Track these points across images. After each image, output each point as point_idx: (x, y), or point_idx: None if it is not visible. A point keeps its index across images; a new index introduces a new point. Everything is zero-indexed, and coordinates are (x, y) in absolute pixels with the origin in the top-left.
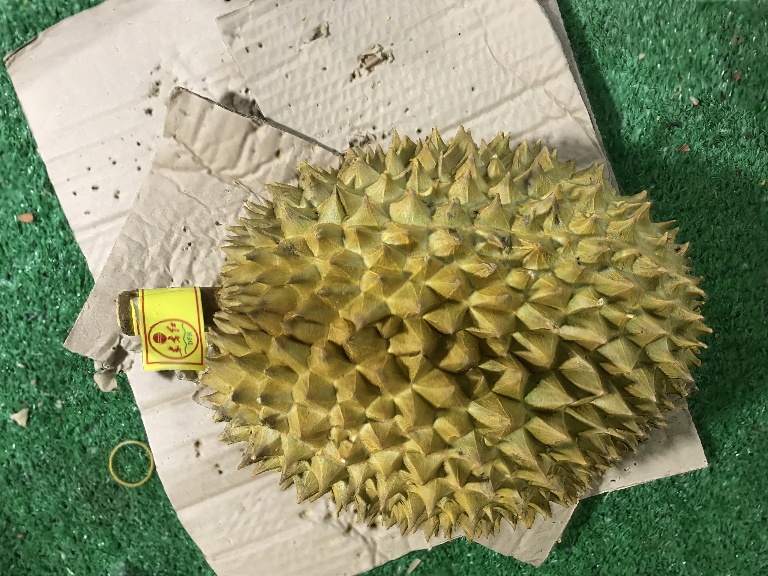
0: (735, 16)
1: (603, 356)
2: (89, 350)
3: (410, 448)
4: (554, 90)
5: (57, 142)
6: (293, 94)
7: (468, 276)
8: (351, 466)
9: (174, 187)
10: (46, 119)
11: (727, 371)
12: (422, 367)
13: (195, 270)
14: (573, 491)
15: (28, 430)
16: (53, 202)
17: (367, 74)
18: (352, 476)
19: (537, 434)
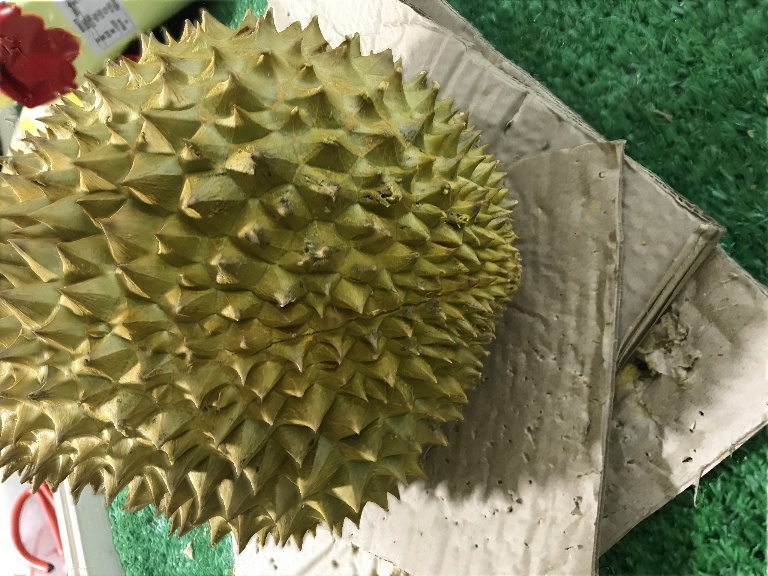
0: None
1: None
2: None
3: None
4: (386, 17)
5: None
6: None
7: None
8: None
9: None
10: None
11: None
12: None
13: None
14: (310, 415)
15: (195, 563)
16: None
17: None
18: None
19: None
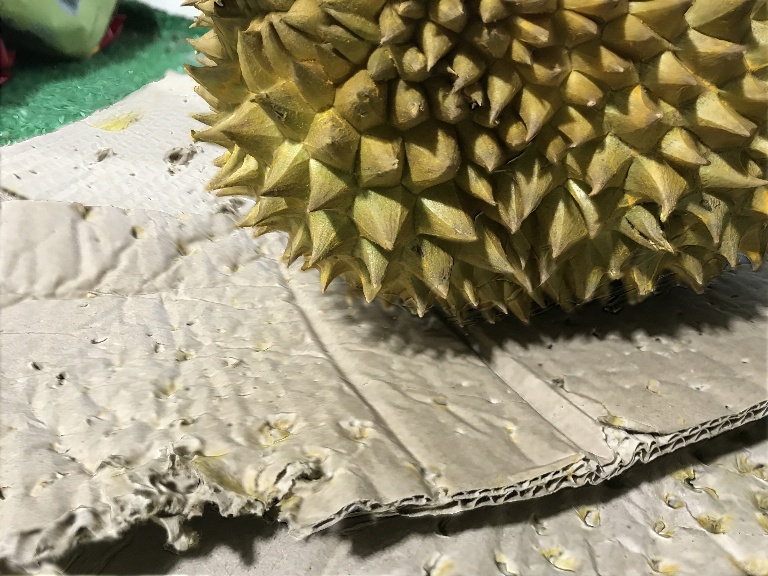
0: None
1: None
2: None
3: None
4: None
5: None
6: (110, 198)
7: None
8: None
9: None
10: None
11: None
12: None
13: (100, 398)
14: None
15: None
16: None
17: (185, 167)
18: None
19: None
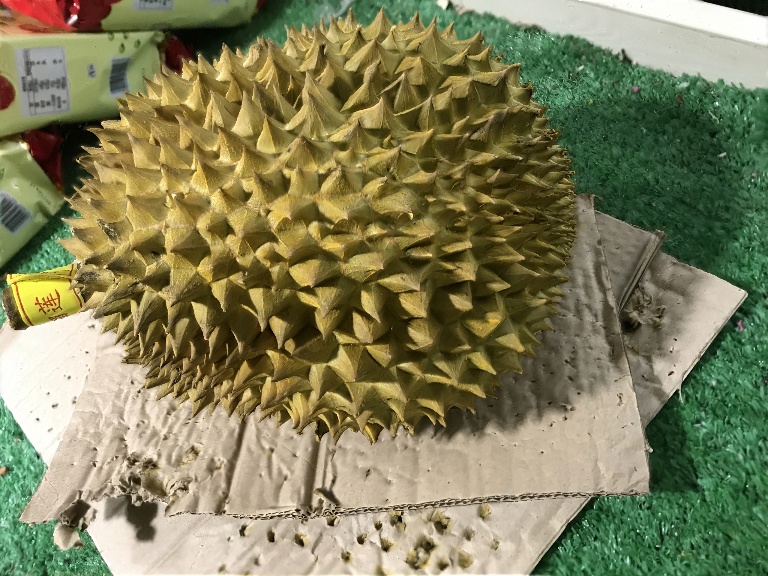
0: (491, 50)
1: (400, 72)
2: (47, 515)
3: (241, 170)
4: None
5: (21, 390)
6: None
7: (248, 69)
8: (199, 223)
9: (117, 356)
10: (11, 379)
11: (690, 221)
12: (225, 115)
13: (148, 409)
14: None
15: None
16: (23, 445)
17: None
18: (211, 243)
19: (365, 124)
